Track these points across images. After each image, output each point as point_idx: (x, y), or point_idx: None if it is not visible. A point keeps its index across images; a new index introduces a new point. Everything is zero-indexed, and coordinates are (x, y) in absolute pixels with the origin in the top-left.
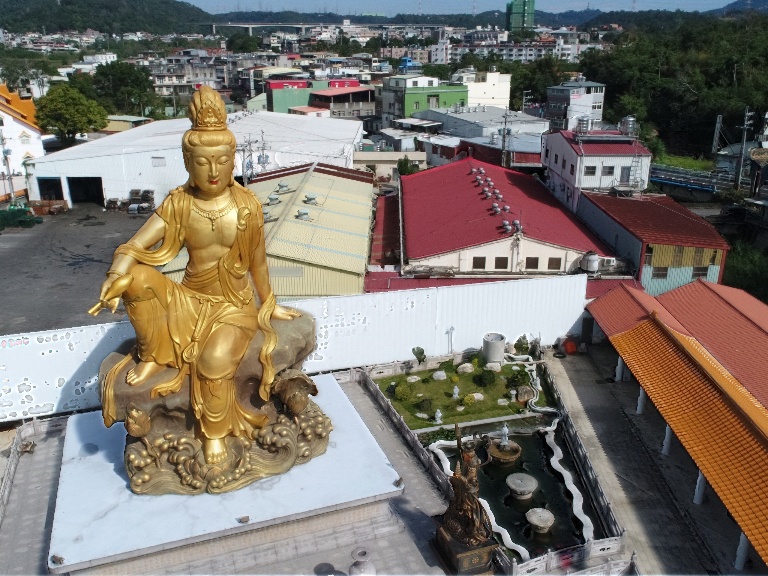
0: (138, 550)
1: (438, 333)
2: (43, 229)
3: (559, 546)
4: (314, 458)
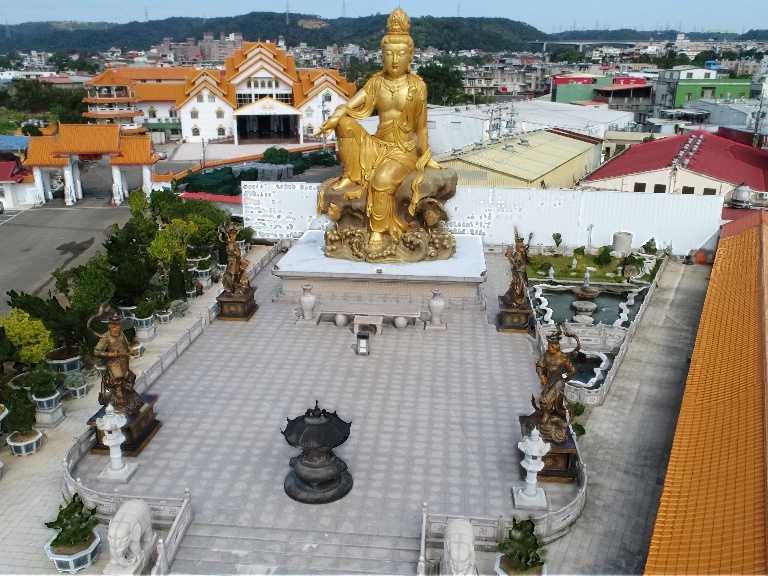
0: (318, 273)
1: (580, 229)
2: (339, 168)
3: None
4: (439, 260)
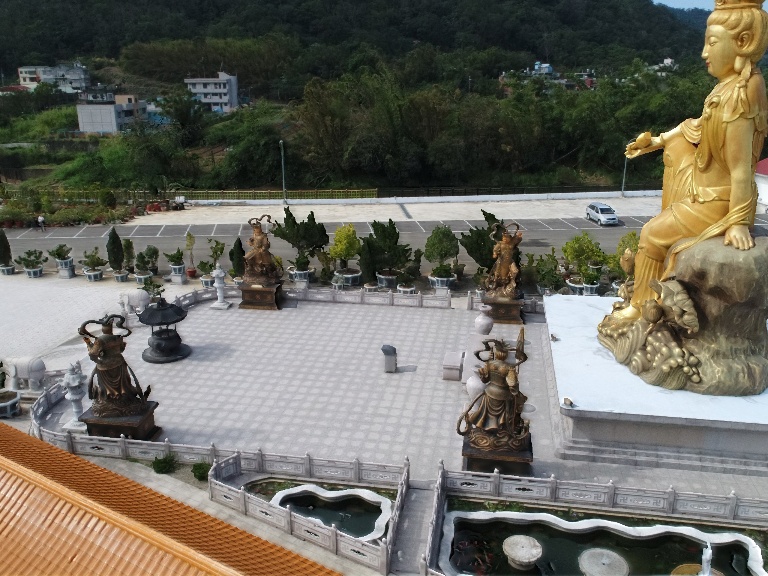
0: None
1: None
2: None
3: None
4: (640, 377)
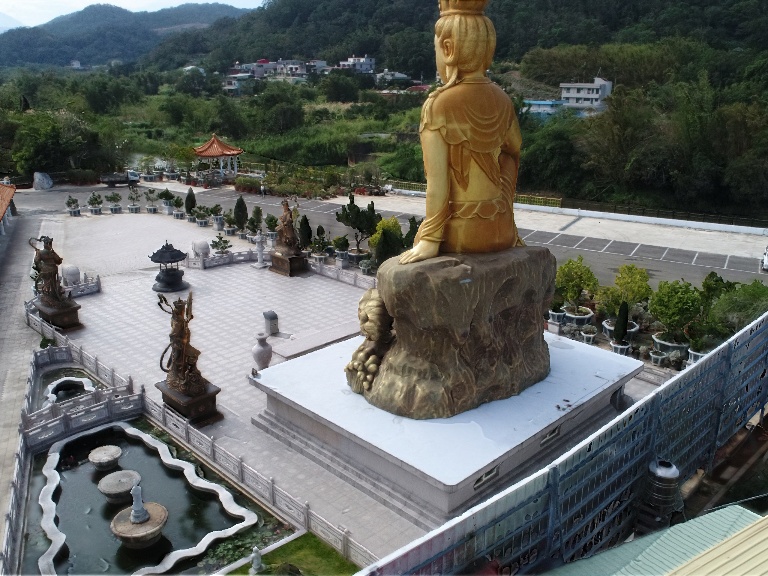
0: None
1: None
2: None
3: (88, 471)
4: None
